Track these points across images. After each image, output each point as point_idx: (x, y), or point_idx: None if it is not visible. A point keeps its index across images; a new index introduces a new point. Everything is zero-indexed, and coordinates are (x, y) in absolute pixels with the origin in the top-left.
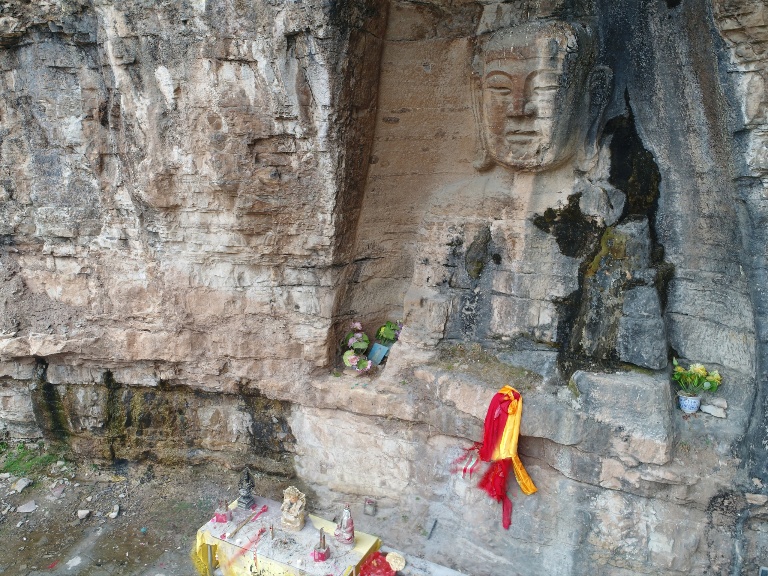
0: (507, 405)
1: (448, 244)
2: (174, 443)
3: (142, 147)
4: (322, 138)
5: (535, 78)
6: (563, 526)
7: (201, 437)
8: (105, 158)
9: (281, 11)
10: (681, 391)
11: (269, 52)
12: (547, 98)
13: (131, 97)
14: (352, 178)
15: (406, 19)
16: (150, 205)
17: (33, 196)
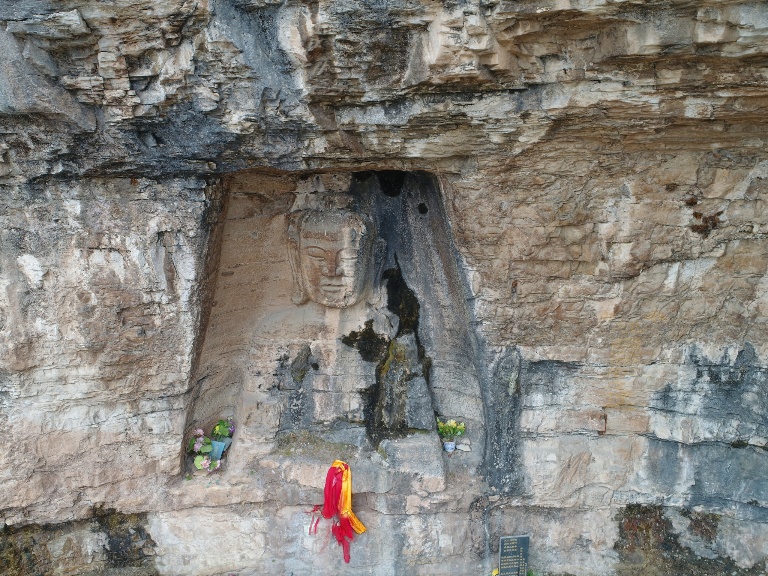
0: (341, 475)
1: (277, 360)
2: None
3: None
4: (184, 302)
5: (342, 252)
6: (386, 548)
7: (52, 568)
8: None
9: (155, 217)
10: (444, 439)
11: (142, 245)
12: (350, 264)
13: None
14: (203, 324)
15: (240, 205)
16: (4, 370)
17: None
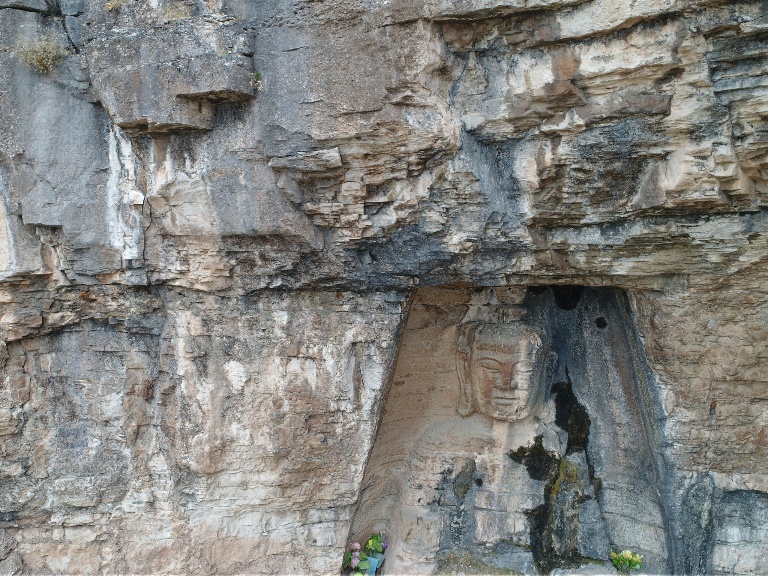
0: None
1: (440, 473)
2: None
3: (199, 424)
4: (366, 411)
5: (517, 365)
6: None
7: None
8: (141, 428)
9: (352, 328)
10: (619, 571)
11: (337, 354)
12: (525, 377)
13: (194, 382)
14: None
15: (418, 316)
16: (196, 472)
17: (51, 469)
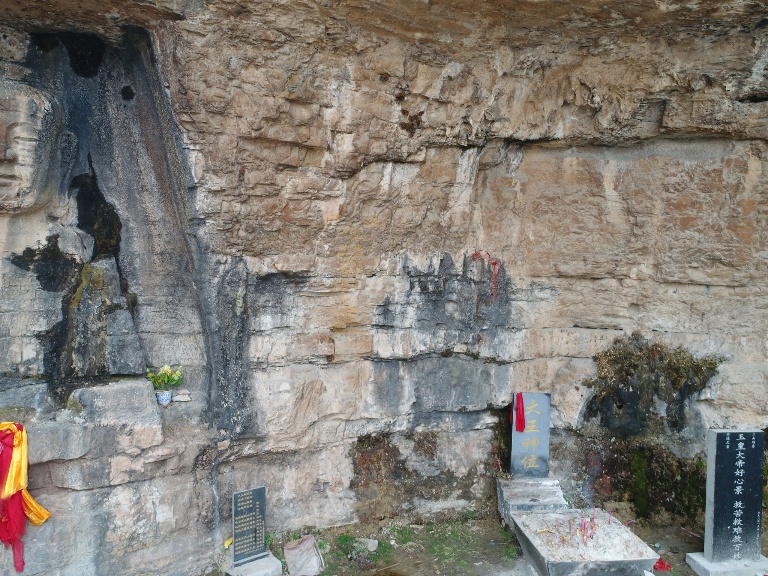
0: (11, 438)
1: None
2: None
3: None
4: None
5: (16, 129)
6: (81, 538)
7: None
8: None
9: None
10: (156, 390)
11: None
12: (28, 148)
13: None
14: None
15: None
16: None
17: None
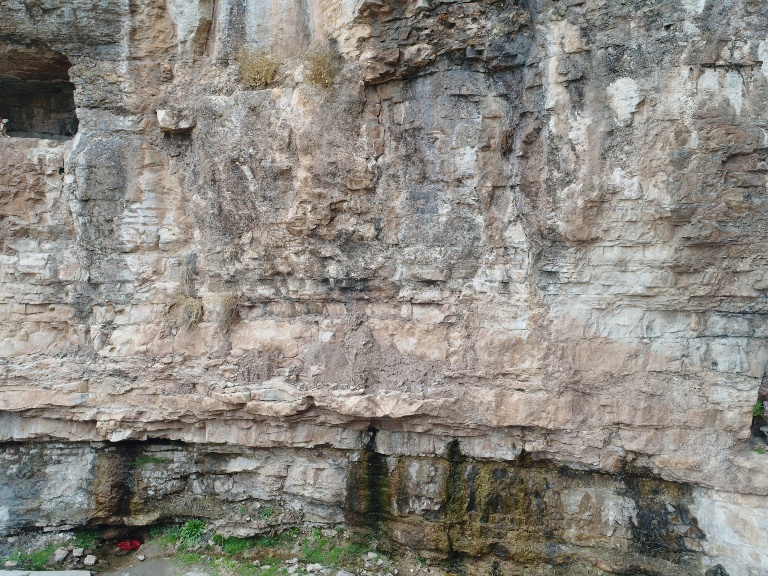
0: None
1: None
2: (529, 534)
3: (570, 171)
4: None
5: None
6: None
7: (563, 528)
8: (496, 191)
9: None
10: None
11: None
12: None
13: (566, 117)
14: None
15: None
16: (563, 238)
17: (401, 236)
